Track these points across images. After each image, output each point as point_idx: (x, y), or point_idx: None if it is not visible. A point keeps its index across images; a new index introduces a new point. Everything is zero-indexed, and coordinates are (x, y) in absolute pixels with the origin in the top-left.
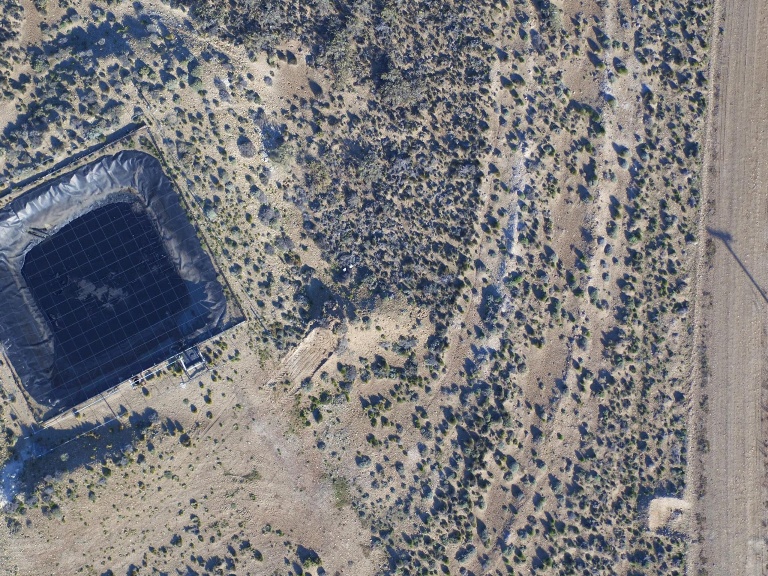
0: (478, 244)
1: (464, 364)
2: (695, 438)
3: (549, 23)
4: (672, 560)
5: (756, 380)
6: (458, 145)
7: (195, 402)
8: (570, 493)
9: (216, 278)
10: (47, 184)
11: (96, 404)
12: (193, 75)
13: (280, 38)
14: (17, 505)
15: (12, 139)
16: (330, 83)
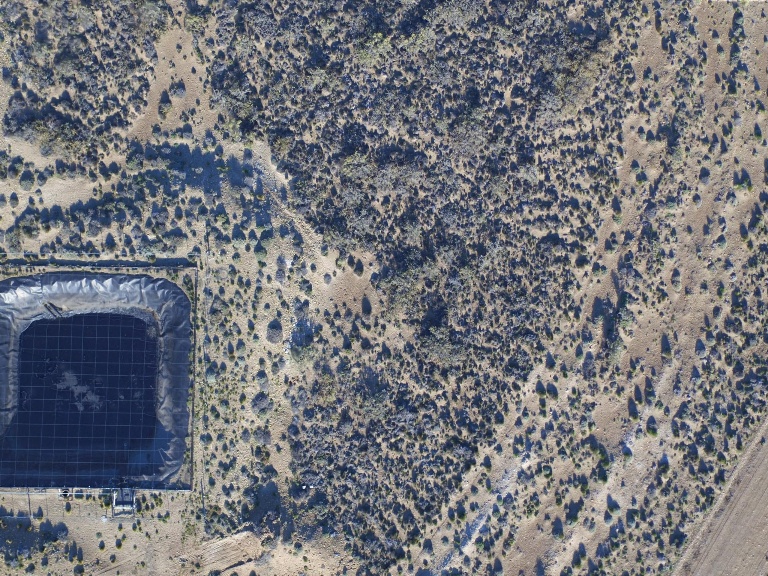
0: (437, 525)
1: None
2: None
3: (608, 354)
4: None
5: None
6: (467, 424)
7: (106, 540)
8: None
9: (185, 437)
10: (83, 274)
11: (19, 495)
12: (262, 244)
13: (359, 245)
14: None
15: (74, 218)
16: (382, 309)
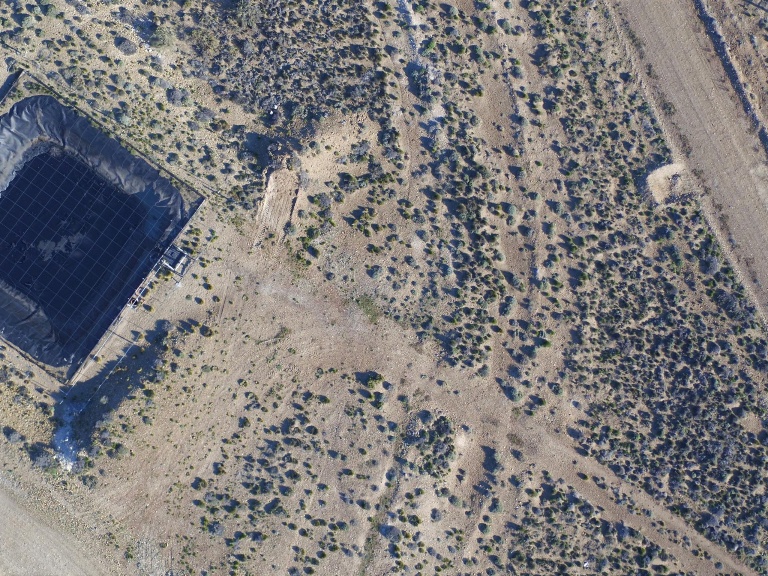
0: (380, 33)
1: (421, 144)
2: (658, 106)
3: None
4: (691, 221)
5: (686, 29)
6: None
7: (197, 294)
8: (572, 208)
9: (159, 175)
10: None
11: (109, 341)
12: (43, 4)
13: None
14: (83, 461)
15: None
16: None
